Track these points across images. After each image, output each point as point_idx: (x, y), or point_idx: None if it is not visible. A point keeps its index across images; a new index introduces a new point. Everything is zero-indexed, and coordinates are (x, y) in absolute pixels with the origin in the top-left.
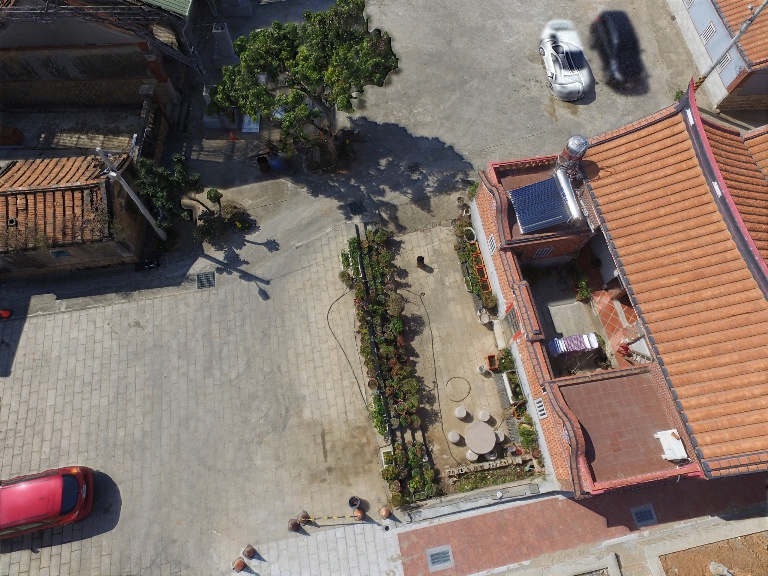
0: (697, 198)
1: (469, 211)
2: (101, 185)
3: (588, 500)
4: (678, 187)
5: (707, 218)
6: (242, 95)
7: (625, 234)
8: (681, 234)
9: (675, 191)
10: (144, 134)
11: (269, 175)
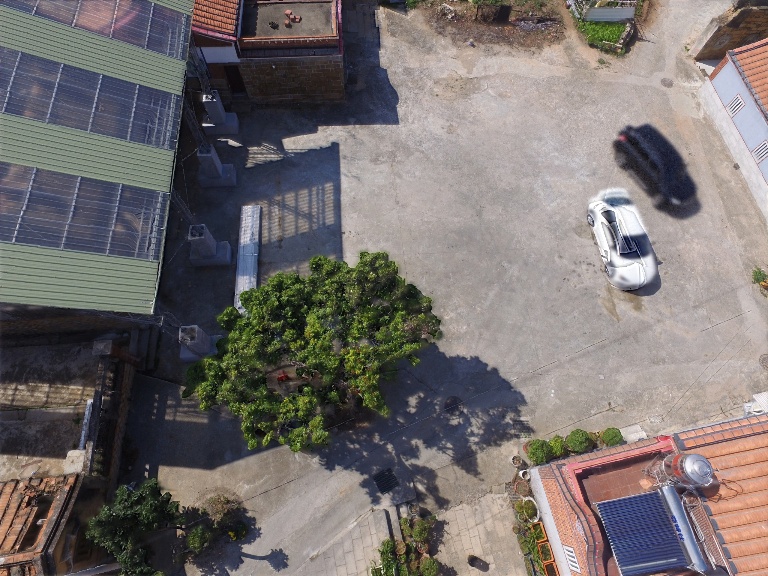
0: None
1: (527, 473)
2: (35, 563)
3: None
4: None
5: None
6: None
7: None
8: None
9: None
10: None
11: None
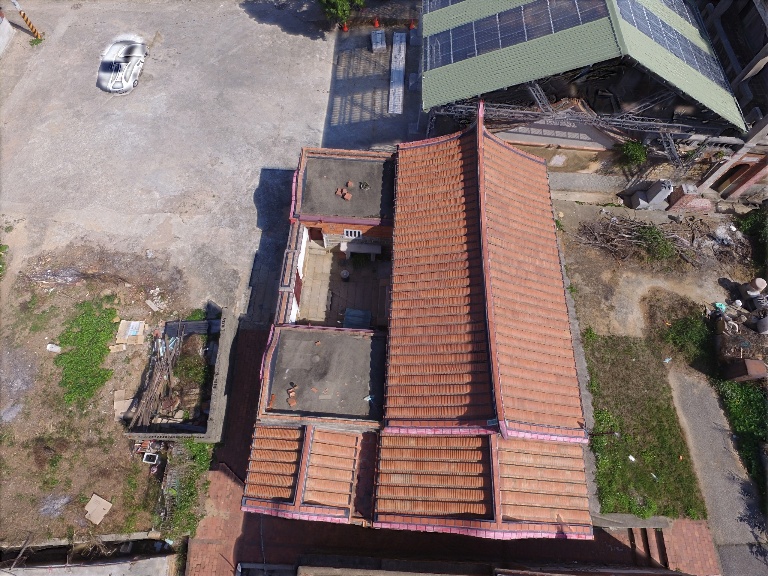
0: None
1: None
2: None
3: None
4: None
5: None
6: None
7: None
8: None
9: None
10: None
11: None
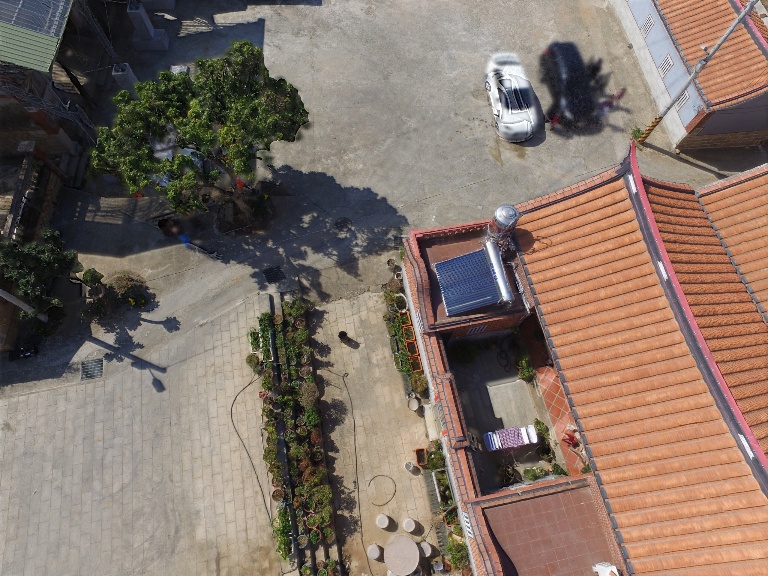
0: (641, 279)
1: (401, 275)
2: None
3: None
4: (620, 265)
5: (652, 304)
6: (121, 161)
7: (561, 320)
8: (623, 322)
9: (617, 270)
10: (23, 198)
11: (174, 239)
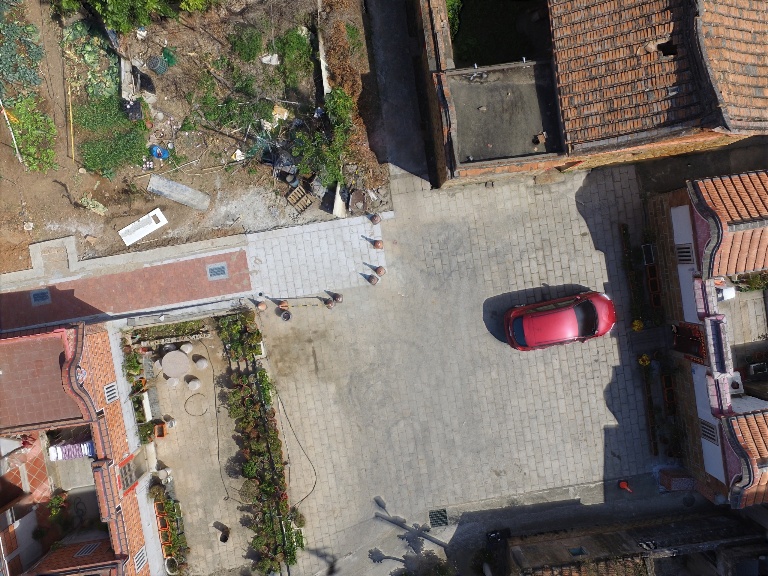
0: None
1: None
2: None
3: (87, 311)
4: None
5: None
6: None
7: None
8: None
9: None
10: None
11: None
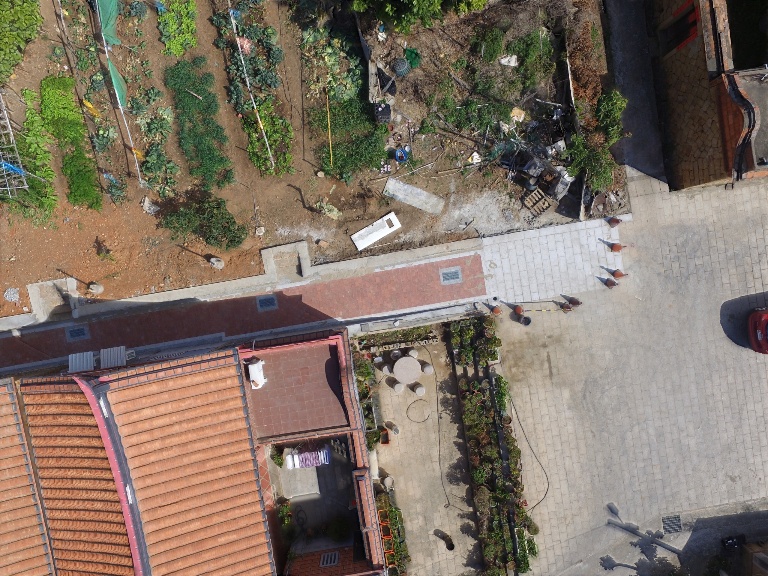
0: None
1: None
2: None
3: (315, 316)
4: None
5: None
6: None
7: None
8: None
9: None
10: None
11: None
